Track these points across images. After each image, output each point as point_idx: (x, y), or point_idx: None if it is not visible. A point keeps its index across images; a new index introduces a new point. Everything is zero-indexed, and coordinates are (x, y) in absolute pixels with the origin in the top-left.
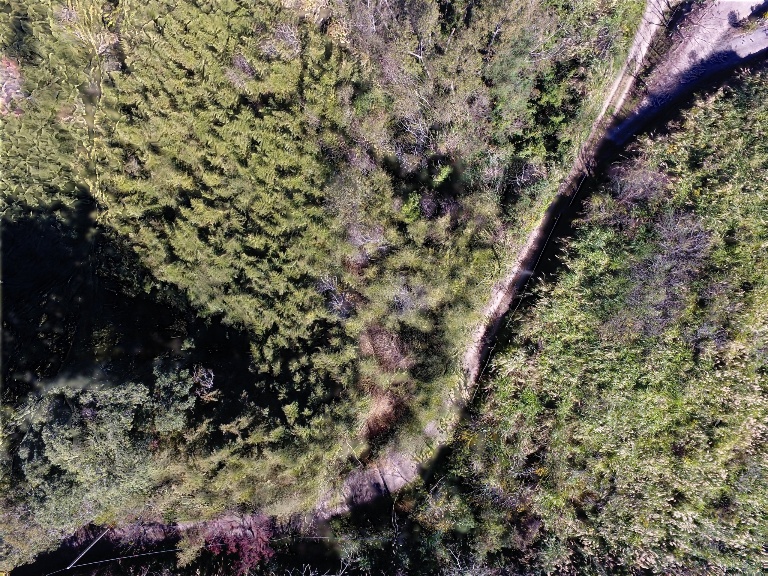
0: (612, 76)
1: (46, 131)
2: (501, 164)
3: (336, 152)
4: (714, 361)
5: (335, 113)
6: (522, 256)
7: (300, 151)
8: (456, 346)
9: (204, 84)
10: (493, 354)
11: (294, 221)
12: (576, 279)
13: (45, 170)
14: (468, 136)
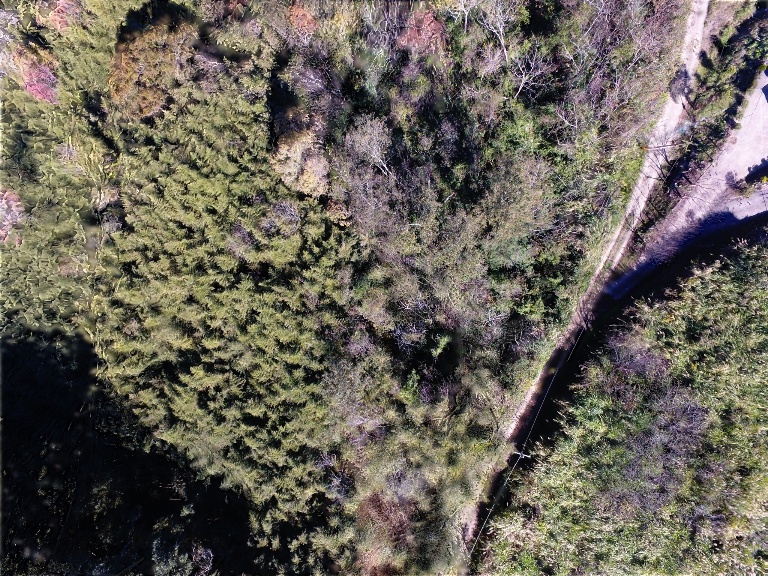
0: (610, 232)
1: (46, 252)
2: (499, 327)
3: (335, 329)
4: (710, 542)
5: (334, 290)
6: (520, 412)
7: (299, 326)
8: (454, 506)
9: (204, 247)
10: (491, 518)
11: (293, 398)
12: (574, 447)
13: (45, 291)
14: (467, 304)
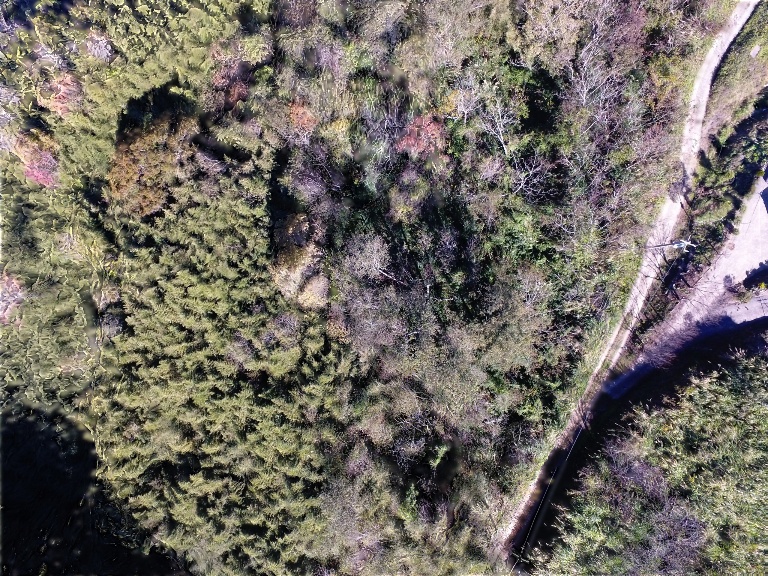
0: (608, 333)
1: (47, 331)
2: (498, 432)
3: (334, 442)
4: None
5: (333, 404)
6: (519, 512)
7: (299, 438)
8: None
9: (204, 351)
10: None
11: (292, 511)
12: (572, 555)
13: (45, 370)
14: (465, 412)
